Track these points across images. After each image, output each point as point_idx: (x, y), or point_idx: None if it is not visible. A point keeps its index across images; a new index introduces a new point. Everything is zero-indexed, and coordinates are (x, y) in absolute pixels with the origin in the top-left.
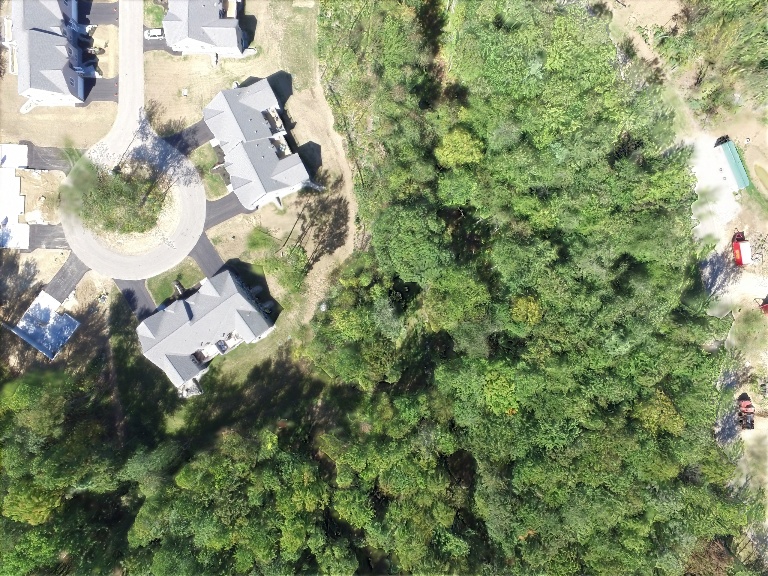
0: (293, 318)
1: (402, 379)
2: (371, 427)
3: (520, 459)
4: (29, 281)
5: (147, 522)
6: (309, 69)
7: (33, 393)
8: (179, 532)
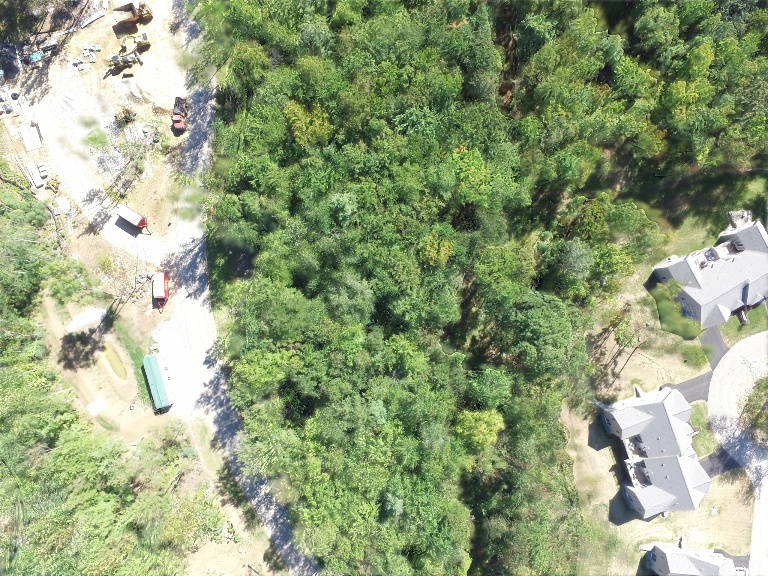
0: (635, 275)
1: (534, 200)
2: (603, 155)
3: None
4: None
5: None
6: (590, 525)
7: None
8: None
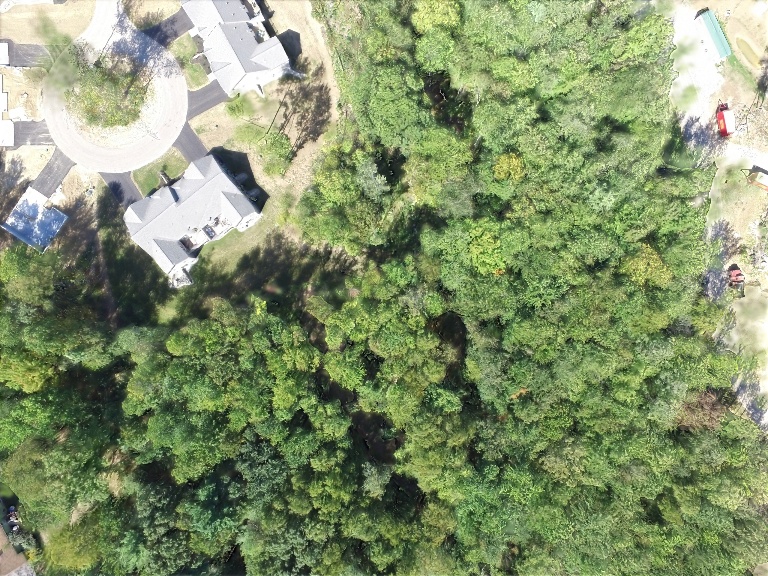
0: (279, 205)
1: None
2: (359, 292)
3: (509, 322)
4: (16, 178)
5: (139, 383)
6: None
7: (21, 263)
8: (172, 394)
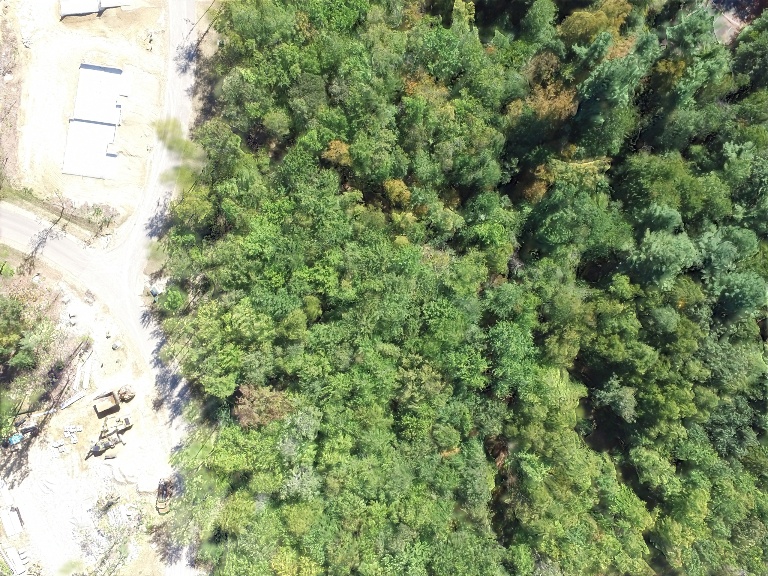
0: None
1: None
2: None
3: None
4: None
5: None
6: None
7: None
8: None
